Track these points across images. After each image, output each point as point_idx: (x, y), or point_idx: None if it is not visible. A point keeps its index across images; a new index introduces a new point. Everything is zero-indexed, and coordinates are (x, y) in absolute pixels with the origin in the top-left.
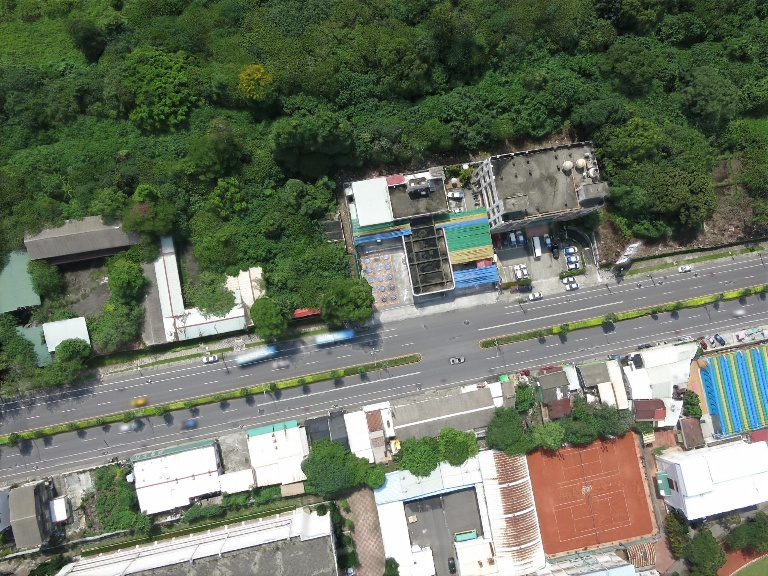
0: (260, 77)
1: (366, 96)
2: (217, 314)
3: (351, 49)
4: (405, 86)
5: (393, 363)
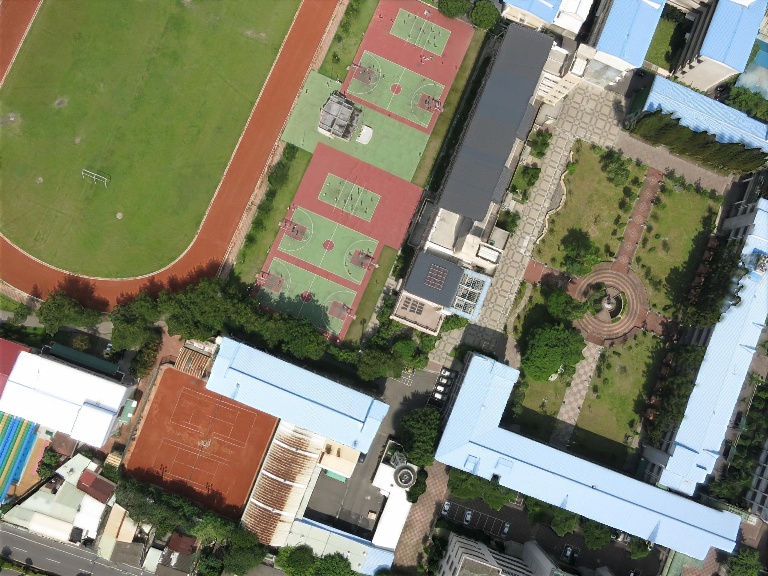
0: None
1: None
2: None
3: None
4: None
5: None
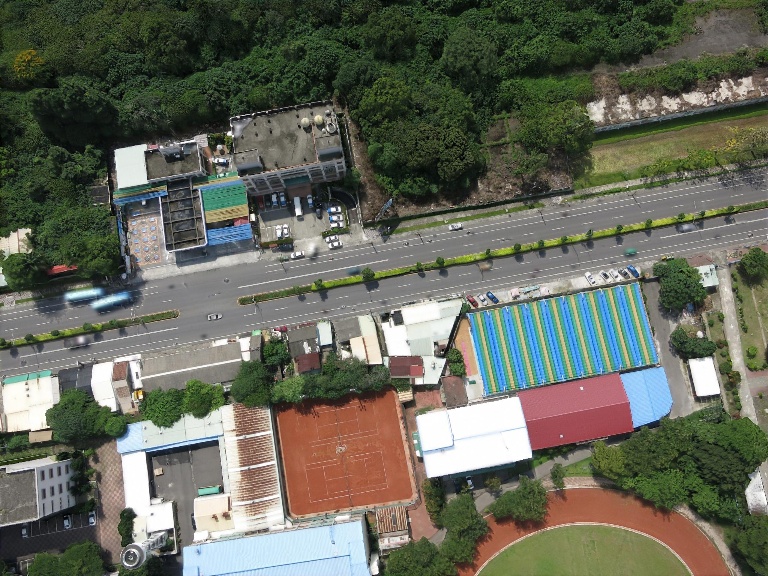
0: (31, 59)
1: (134, 73)
2: None
3: (118, 32)
4: (165, 61)
5: (151, 319)
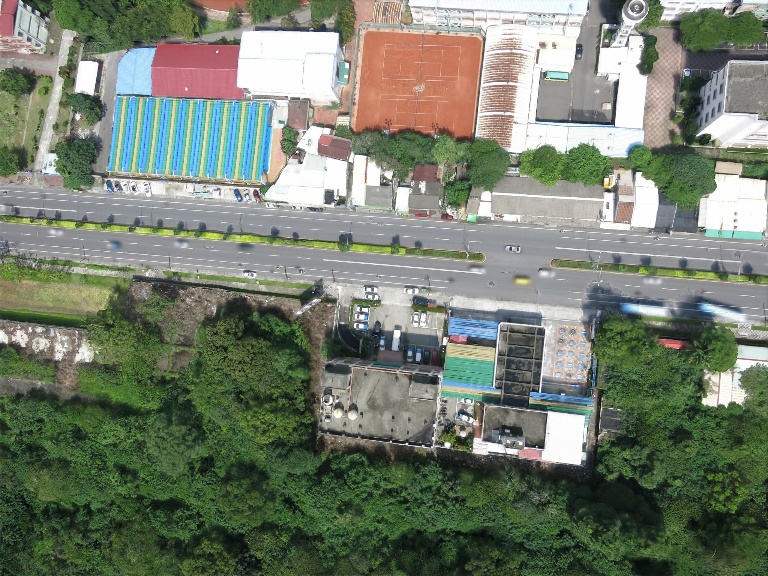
0: None
1: (538, 554)
2: (765, 369)
3: None
4: (496, 552)
5: (582, 265)
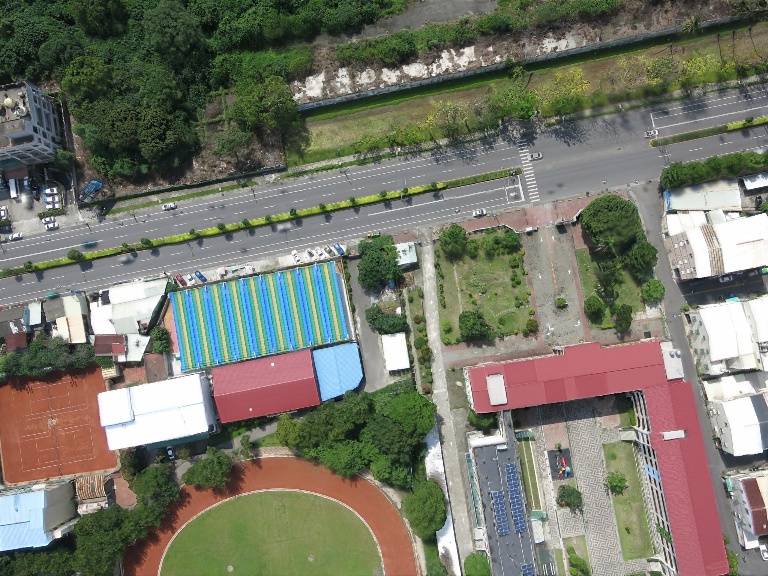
0: None
1: None
2: None
3: None
4: None
5: None
